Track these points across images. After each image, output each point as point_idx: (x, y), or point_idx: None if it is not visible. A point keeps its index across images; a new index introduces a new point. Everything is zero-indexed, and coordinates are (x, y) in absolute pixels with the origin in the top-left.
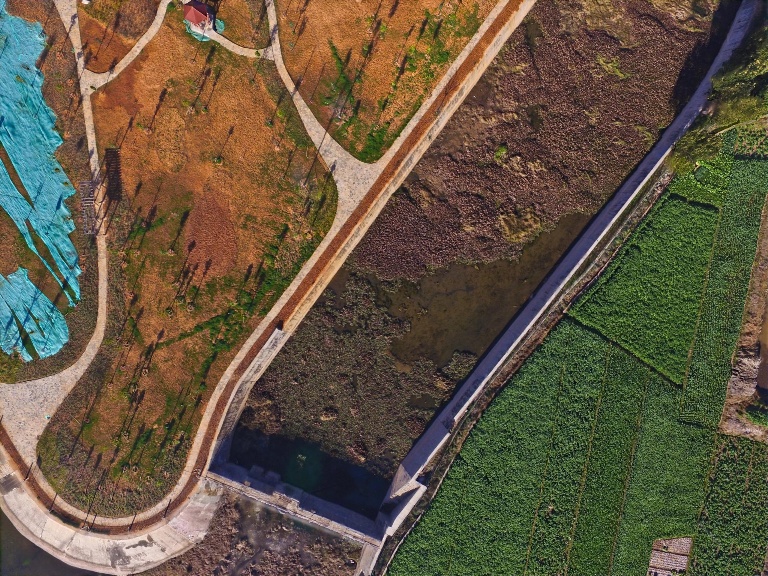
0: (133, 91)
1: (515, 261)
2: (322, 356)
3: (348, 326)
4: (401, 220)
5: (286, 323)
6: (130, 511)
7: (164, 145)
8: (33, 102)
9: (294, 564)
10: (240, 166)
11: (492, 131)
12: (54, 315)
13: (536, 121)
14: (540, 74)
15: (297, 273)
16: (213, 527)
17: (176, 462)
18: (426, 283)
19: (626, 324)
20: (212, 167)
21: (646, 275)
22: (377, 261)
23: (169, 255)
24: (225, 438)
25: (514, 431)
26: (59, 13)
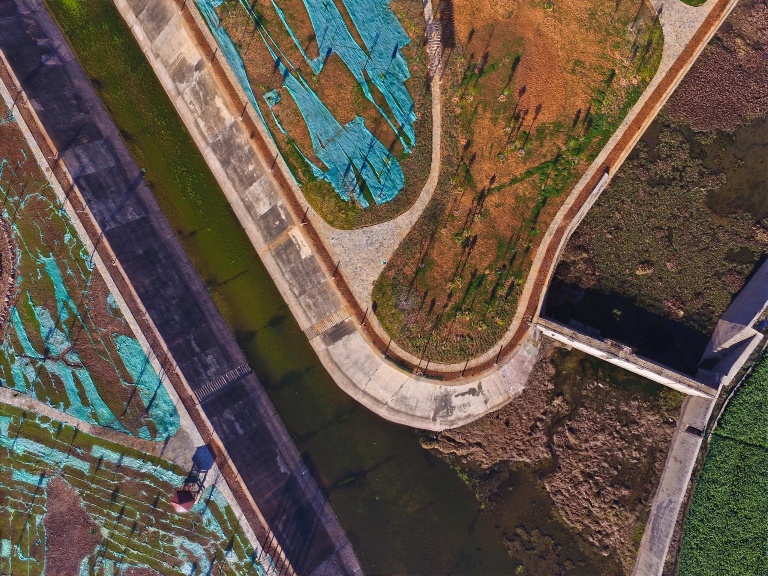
0: None
1: None
2: (636, 209)
3: (661, 179)
4: (716, 69)
5: (612, 170)
6: (463, 357)
7: None
8: None
9: (611, 421)
10: (569, 11)
11: None
12: (390, 161)
13: None
14: None
15: (623, 119)
16: (531, 381)
17: (507, 308)
18: (741, 134)
19: None
20: (542, 13)
21: None
22: (692, 111)
23: (501, 101)
24: None
25: None
26: None
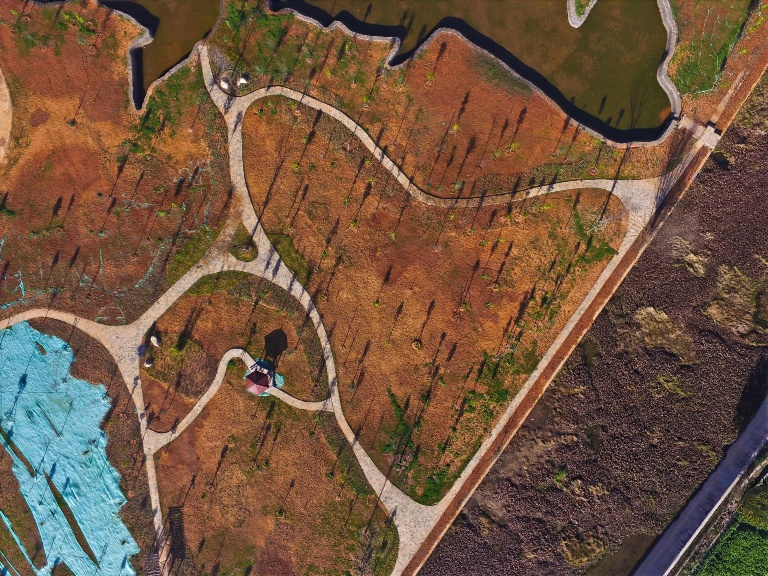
0: (195, 449)
1: None
2: None
3: None
4: (461, 548)
5: None
6: None
7: (226, 501)
8: (98, 463)
9: None
10: (301, 517)
11: (551, 453)
12: None
13: (596, 441)
14: (599, 394)
15: None
16: None
17: None
18: None
19: None
20: (274, 520)
21: None
22: None
23: None
24: None
25: None
26: (122, 375)
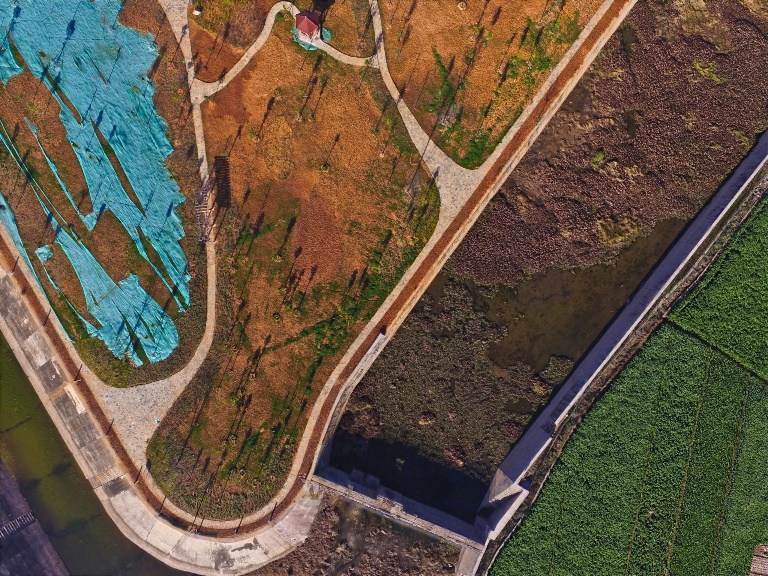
0: (242, 100)
1: (611, 266)
2: (420, 361)
3: (446, 331)
4: (499, 225)
5: (389, 328)
6: (237, 514)
7: (272, 153)
8: (145, 111)
9: (393, 568)
10: (345, 173)
11: (588, 137)
12: (164, 320)
13: (632, 126)
14: (636, 80)
15: (400, 278)
16: (314, 530)
17: (282, 466)
18: (523, 288)
19: (726, 329)
20: (318, 174)
21: (746, 280)
22: (475, 266)
23: (276, 261)
24: (327, 442)
25: (615, 436)
26: (170, 24)
